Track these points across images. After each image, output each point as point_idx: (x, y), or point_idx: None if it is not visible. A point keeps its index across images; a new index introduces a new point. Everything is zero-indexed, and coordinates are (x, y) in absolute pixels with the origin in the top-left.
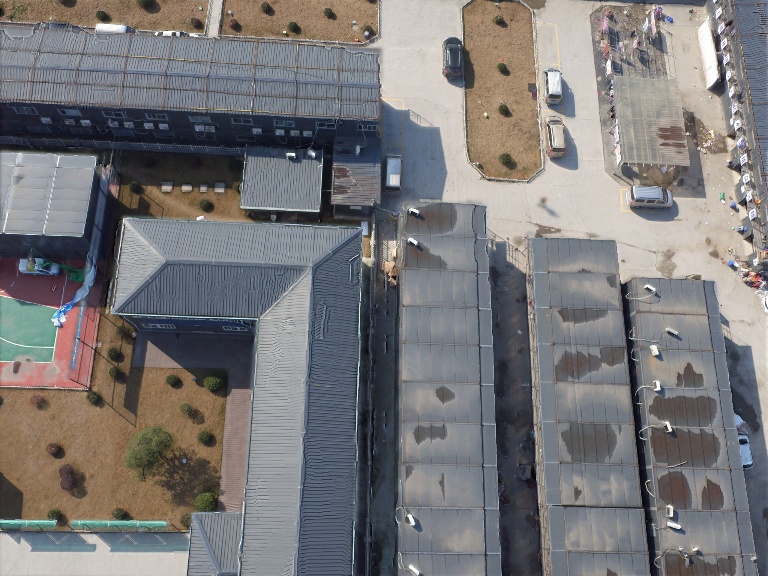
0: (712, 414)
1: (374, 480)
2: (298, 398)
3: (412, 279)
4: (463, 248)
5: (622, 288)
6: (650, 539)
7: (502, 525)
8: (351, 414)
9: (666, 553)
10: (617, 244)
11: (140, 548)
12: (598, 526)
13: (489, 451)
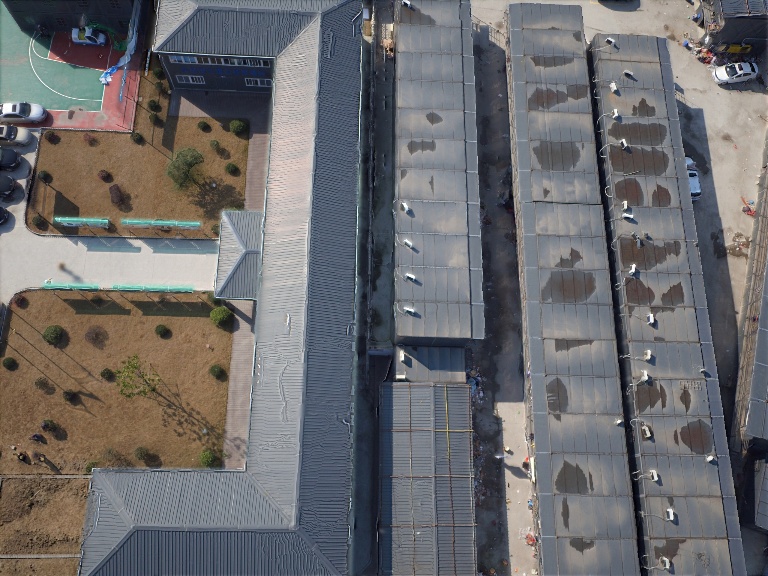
0: (662, 136)
1: (375, 205)
2: (310, 114)
3: (406, 32)
4: (449, 9)
5: (586, 43)
6: (608, 232)
7: (485, 241)
8: (354, 128)
9: (621, 238)
10: (586, 29)
11: (178, 251)
12: (563, 217)
13: (471, 161)
